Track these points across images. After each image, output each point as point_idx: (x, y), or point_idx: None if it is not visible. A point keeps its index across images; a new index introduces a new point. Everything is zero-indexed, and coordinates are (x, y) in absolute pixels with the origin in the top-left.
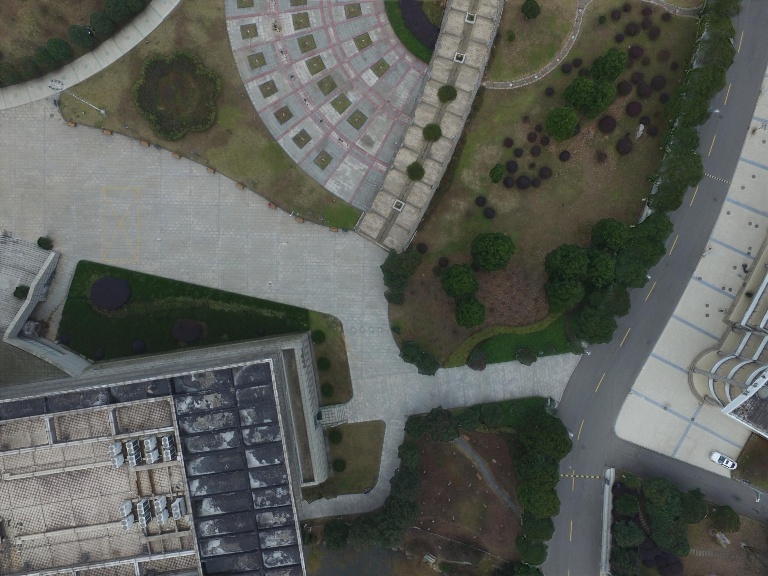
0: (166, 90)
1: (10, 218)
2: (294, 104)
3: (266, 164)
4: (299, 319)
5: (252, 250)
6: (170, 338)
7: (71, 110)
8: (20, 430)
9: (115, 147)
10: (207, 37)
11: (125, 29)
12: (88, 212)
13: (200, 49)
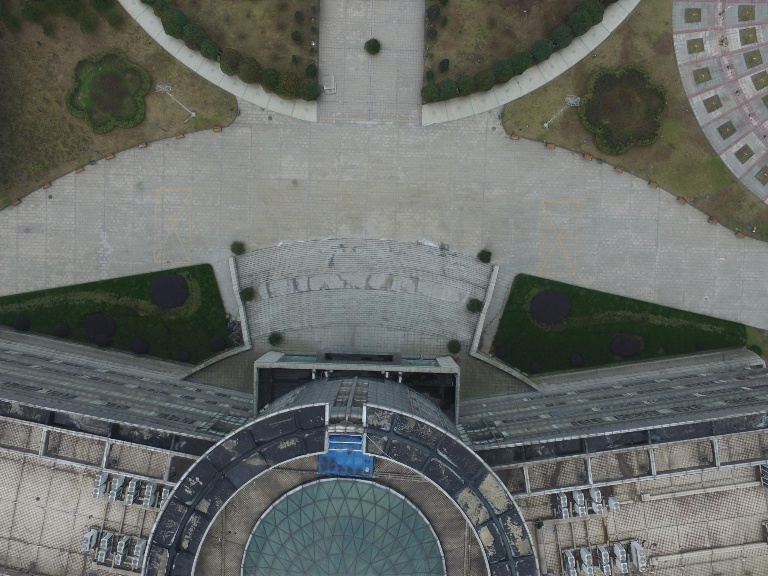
0: (613, 104)
1: (448, 231)
2: (738, 119)
3: (708, 179)
4: (738, 334)
5: (689, 265)
6: (608, 352)
7: (514, 123)
8: (658, 450)
9: (556, 161)
10: (653, 51)
11: (572, 43)
12: (526, 225)
13: (646, 63)
